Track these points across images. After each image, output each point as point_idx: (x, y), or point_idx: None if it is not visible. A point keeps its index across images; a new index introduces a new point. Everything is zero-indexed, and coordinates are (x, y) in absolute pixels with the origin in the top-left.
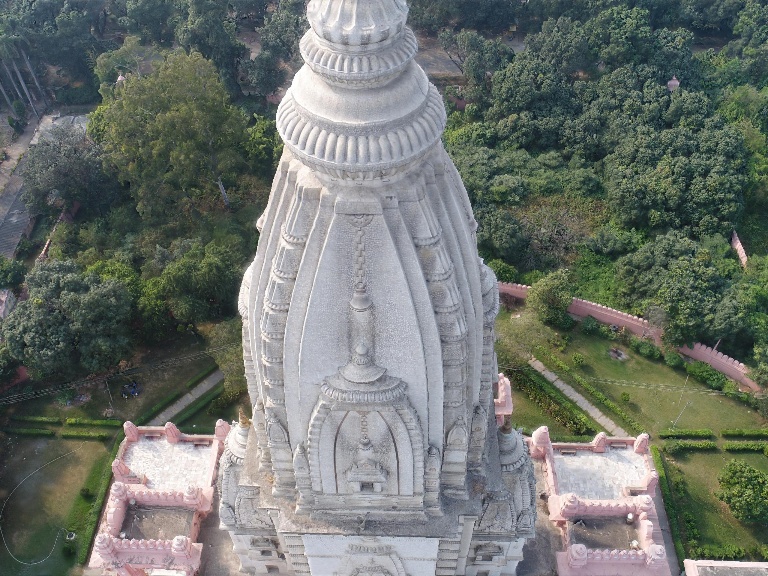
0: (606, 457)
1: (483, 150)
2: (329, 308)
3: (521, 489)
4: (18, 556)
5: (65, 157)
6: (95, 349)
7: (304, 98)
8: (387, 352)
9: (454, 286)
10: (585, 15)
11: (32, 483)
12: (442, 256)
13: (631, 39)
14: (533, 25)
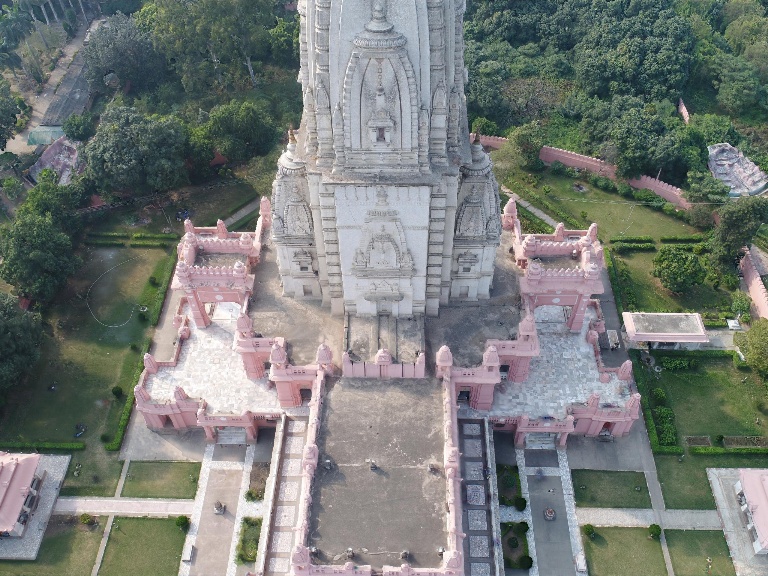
0: None
1: (472, 42)
2: None
3: (488, 194)
4: (104, 322)
5: (122, 37)
6: (159, 168)
7: None
8: (394, 10)
9: None
10: None
11: (110, 276)
12: None
13: None
14: None
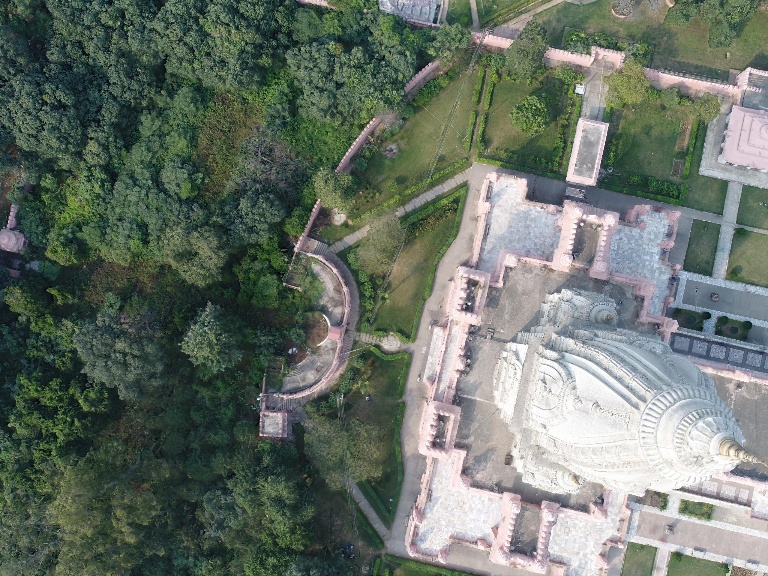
0: (496, 205)
1: (126, 189)
2: None
3: None
4: None
5: None
6: None
7: None
8: None
9: None
10: None
11: None
12: None
13: None
14: None
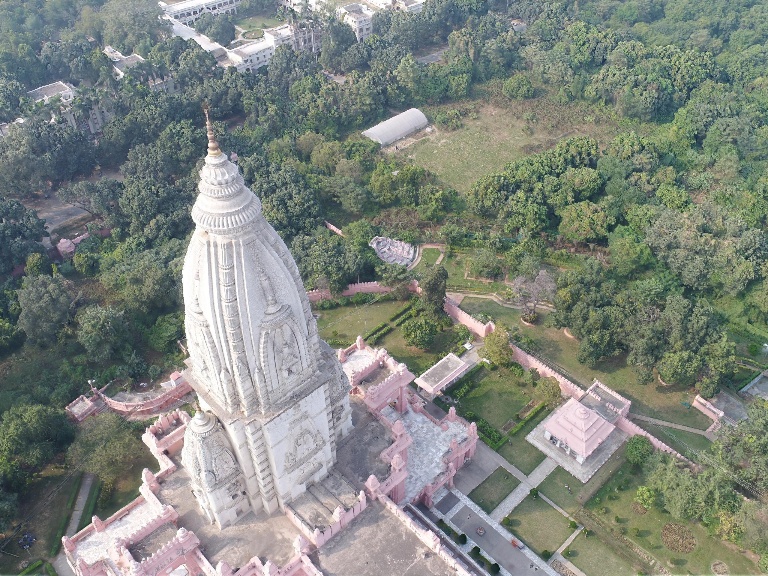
0: (349, 361)
1: (148, 252)
2: (254, 286)
3: (336, 363)
4: None
5: None
6: None
7: (214, 210)
8: (280, 294)
9: (288, 256)
10: (147, 138)
11: None
12: (280, 246)
13: (193, 141)
14: (113, 159)
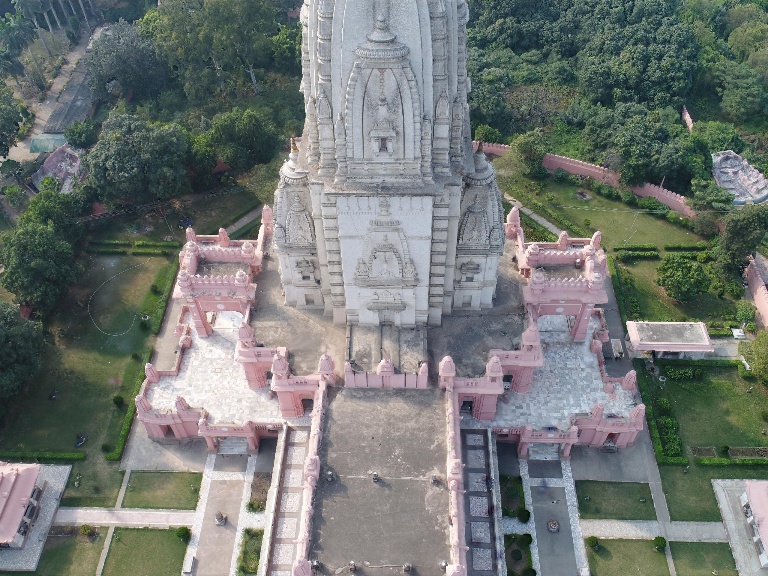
0: None
1: (474, 49)
2: None
3: (492, 204)
4: (105, 330)
5: (125, 45)
6: (161, 176)
7: None
8: (397, 20)
9: None
10: None
11: (111, 284)
12: None
13: None
14: None
